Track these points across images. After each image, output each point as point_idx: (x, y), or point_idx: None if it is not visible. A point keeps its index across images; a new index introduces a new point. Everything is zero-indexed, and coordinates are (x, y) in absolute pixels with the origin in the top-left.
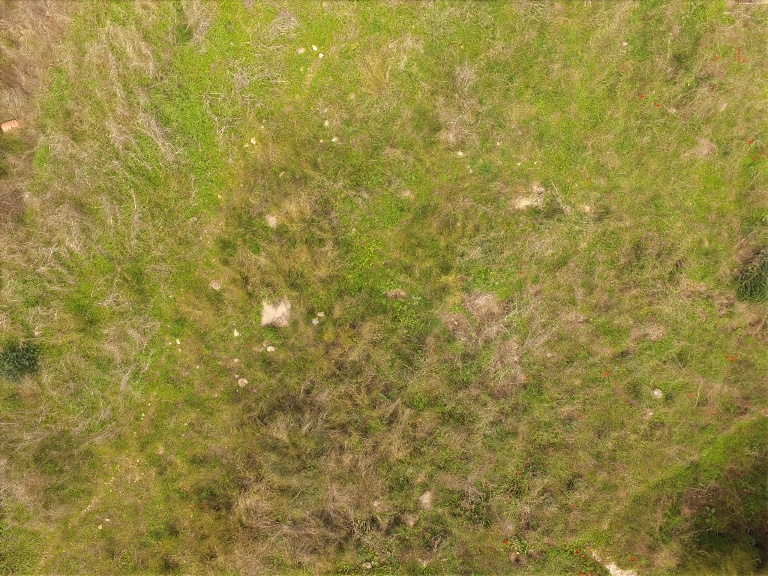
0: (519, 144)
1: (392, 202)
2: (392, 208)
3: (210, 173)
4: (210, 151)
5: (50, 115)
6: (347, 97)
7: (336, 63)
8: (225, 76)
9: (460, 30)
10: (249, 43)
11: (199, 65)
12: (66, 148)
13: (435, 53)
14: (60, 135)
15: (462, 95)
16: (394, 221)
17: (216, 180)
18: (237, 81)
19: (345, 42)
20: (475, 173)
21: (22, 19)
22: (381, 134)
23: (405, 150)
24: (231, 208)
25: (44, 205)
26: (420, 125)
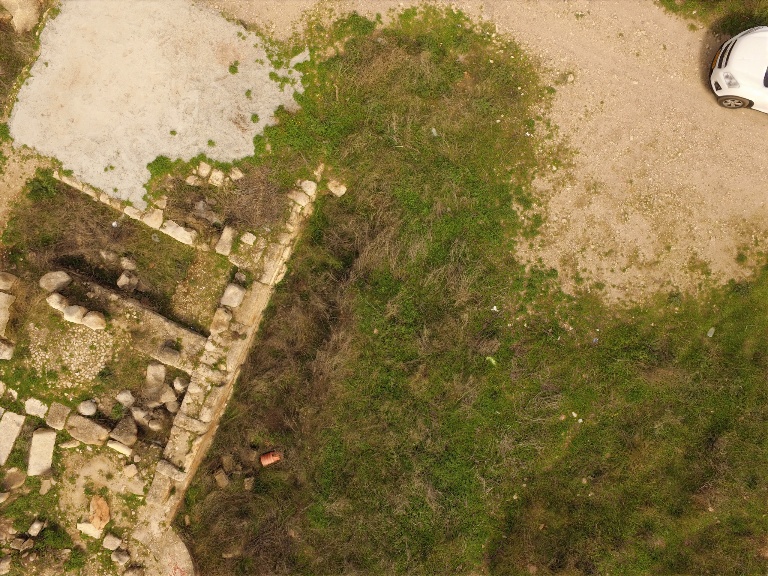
0: (765, 499)
1: (646, 552)
2: (645, 557)
3: (476, 528)
4: (475, 506)
5: (325, 475)
6: (603, 457)
7: (595, 428)
8: (491, 442)
9: (711, 398)
10: (513, 411)
11: (465, 429)
12: (348, 515)
13: (689, 421)
14: (342, 502)
15: (714, 459)
16: (646, 567)
17: (481, 533)
18: (503, 446)
19: (604, 410)
20: (723, 524)
21: (283, 367)
22: (636, 492)
23: (659, 507)
24: (502, 567)
25: (324, 562)
26: (674, 485)
